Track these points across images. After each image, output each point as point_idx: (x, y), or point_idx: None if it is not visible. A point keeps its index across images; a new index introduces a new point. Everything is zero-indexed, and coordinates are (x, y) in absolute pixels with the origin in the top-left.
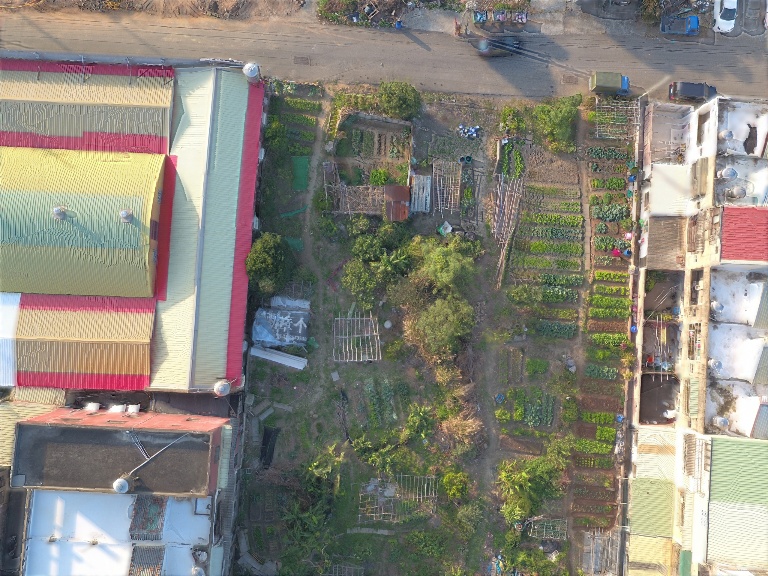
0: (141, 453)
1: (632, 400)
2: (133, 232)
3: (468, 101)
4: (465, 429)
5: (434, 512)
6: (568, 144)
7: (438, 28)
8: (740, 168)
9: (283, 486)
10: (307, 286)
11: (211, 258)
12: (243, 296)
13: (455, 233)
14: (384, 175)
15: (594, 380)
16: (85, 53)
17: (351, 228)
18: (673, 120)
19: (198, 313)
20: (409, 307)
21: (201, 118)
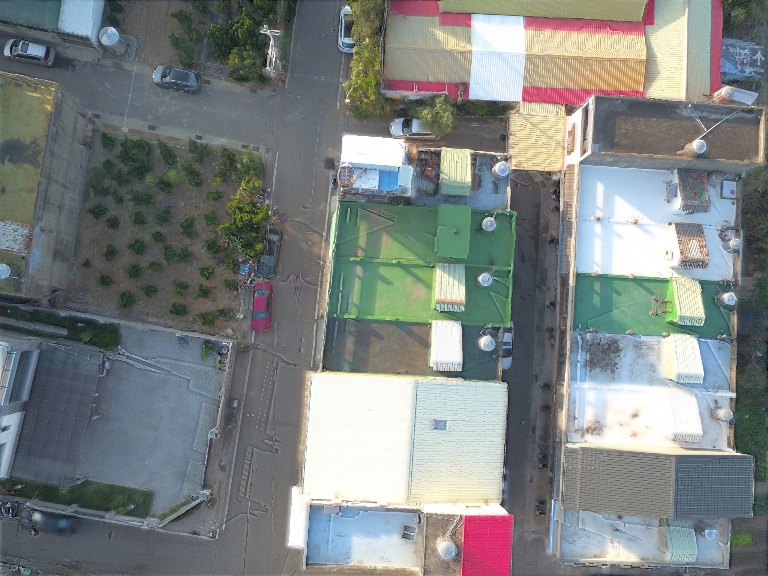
0: (701, 126)
1: None
2: None
3: None
4: None
5: None
6: None
7: None
8: None
9: None
10: (761, 23)
11: None
12: (719, 23)
13: None
14: None
15: None
16: None
17: None
18: None
19: (688, 34)
20: None
21: None
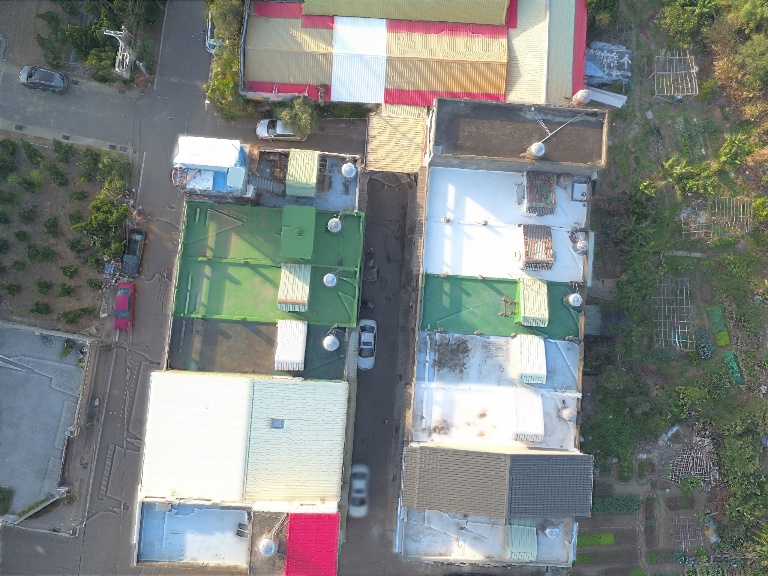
0: (544, 129)
1: None
2: None
3: None
4: None
5: None
6: None
7: None
8: None
9: (607, 211)
10: (629, 27)
11: None
12: (583, 27)
13: None
14: None
15: None
16: None
17: None
18: None
19: (549, 37)
20: (720, 49)
21: None
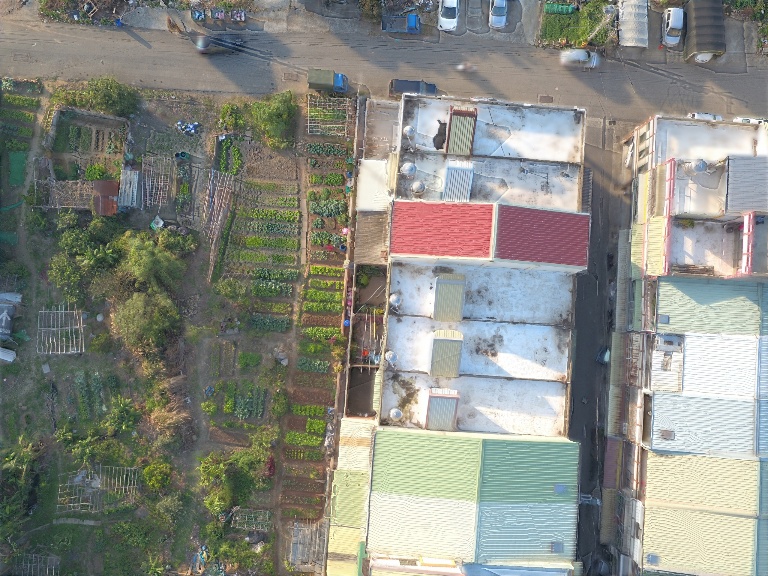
0: None
1: None
2: None
3: (188, 98)
4: (166, 421)
5: (132, 502)
6: (281, 140)
7: (160, 26)
8: (429, 163)
9: None
10: (13, 279)
11: None
12: None
13: (167, 227)
14: (99, 170)
15: (306, 373)
16: None
17: (58, 222)
18: (396, 117)
19: None
20: (115, 300)
21: None
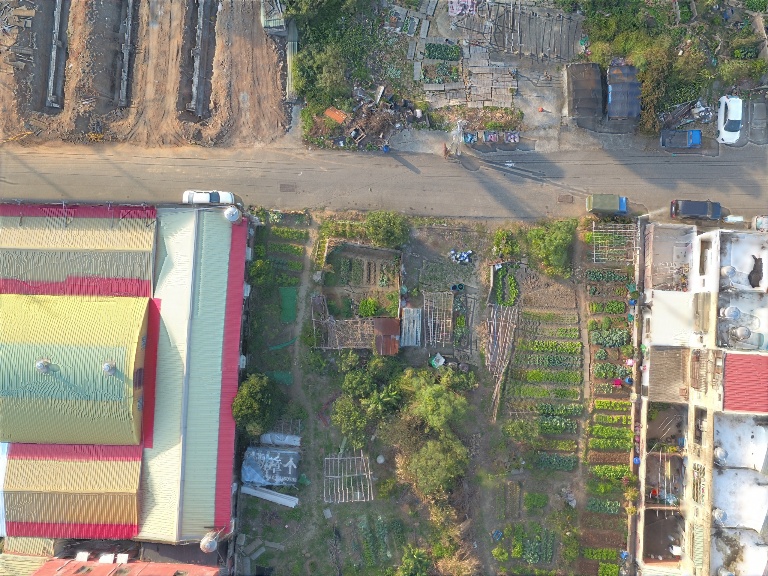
0: None
1: (635, 534)
2: (117, 382)
3: (460, 225)
4: (460, 571)
5: None
6: (564, 270)
7: (428, 149)
8: (745, 302)
9: None
10: (296, 425)
11: (197, 405)
12: (230, 441)
13: (448, 365)
14: (374, 305)
15: (595, 514)
16: (69, 187)
17: (340, 364)
18: (676, 237)
19: (184, 462)
20: (401, 444)
21: (185, 256)
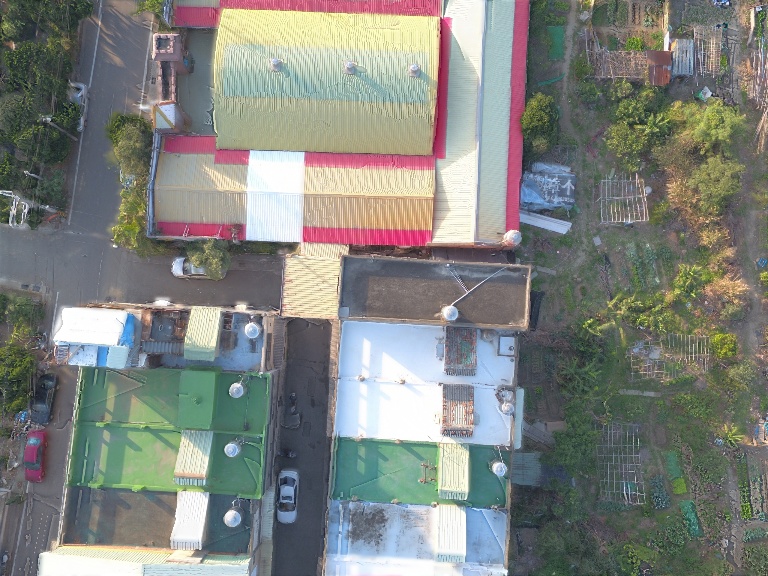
0: (461, 286)
1: None
2: (418, 88)
3: None
4: (735, 289)
5: (706, 370)
6: None
7: None
8: None
9: (550, 348)
10: (573, 149)
11: (490, 116)
12: (519, 155)
13: None
14: (641, 43)
15: None
16: None
17: (615, 92)
18: None
19: (480, 169)
20: (674, 170)
21: None
